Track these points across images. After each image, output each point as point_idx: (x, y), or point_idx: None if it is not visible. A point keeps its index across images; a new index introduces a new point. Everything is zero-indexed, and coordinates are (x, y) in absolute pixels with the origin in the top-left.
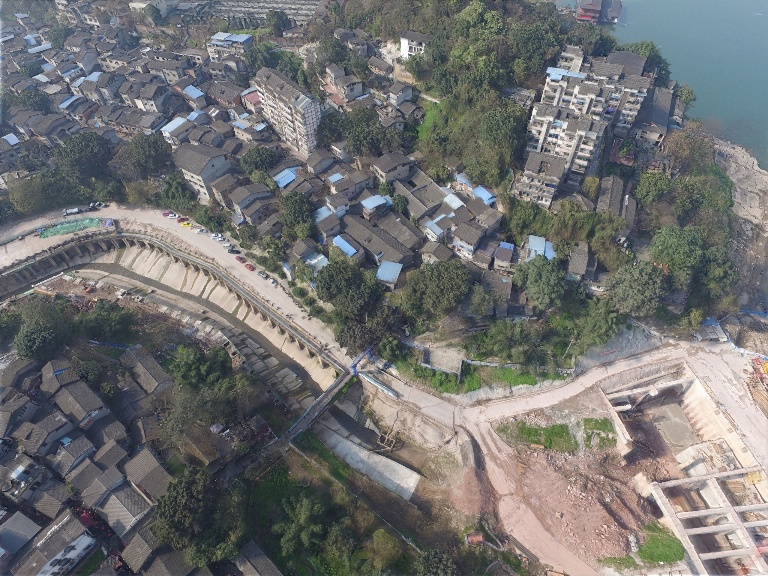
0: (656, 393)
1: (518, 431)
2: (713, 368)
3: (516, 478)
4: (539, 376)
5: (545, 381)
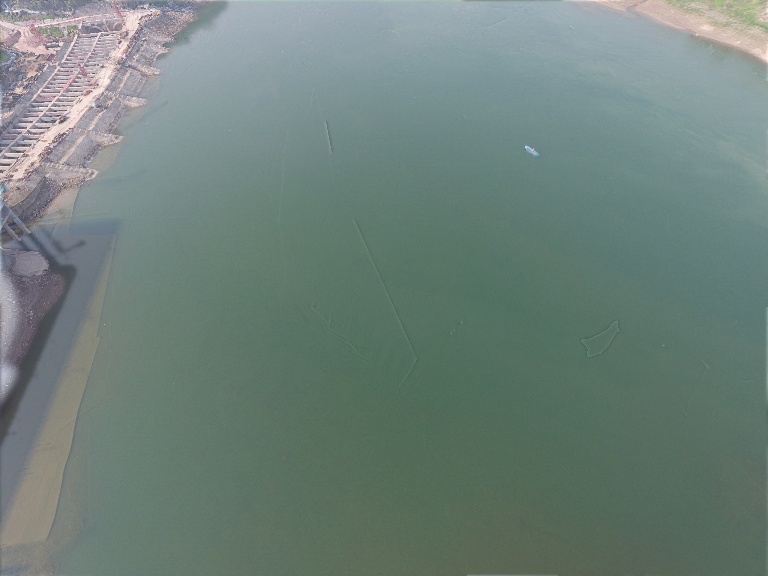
0: (104, 20)
1: (39, 30)
2: None
3: (29, 39)
4: (56, 16)
5: (59, 18)
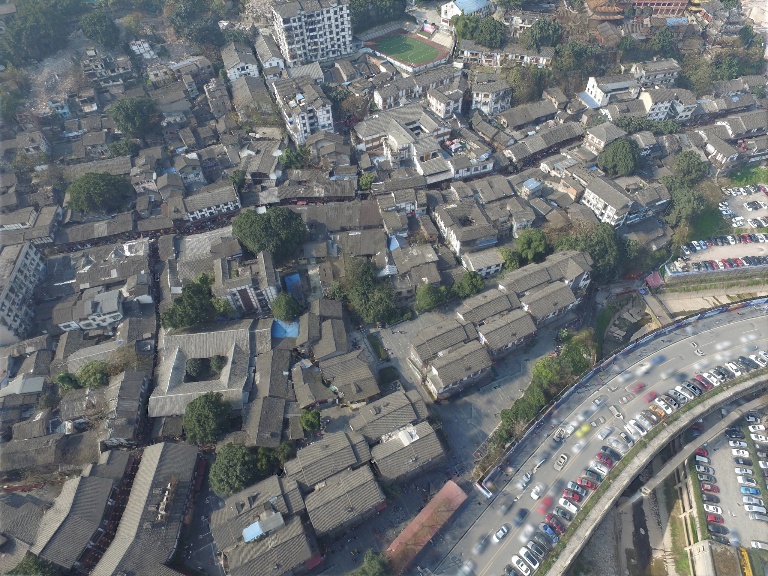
0: None
1: None
2: (761, 4)
3: None
4: None
5: None
